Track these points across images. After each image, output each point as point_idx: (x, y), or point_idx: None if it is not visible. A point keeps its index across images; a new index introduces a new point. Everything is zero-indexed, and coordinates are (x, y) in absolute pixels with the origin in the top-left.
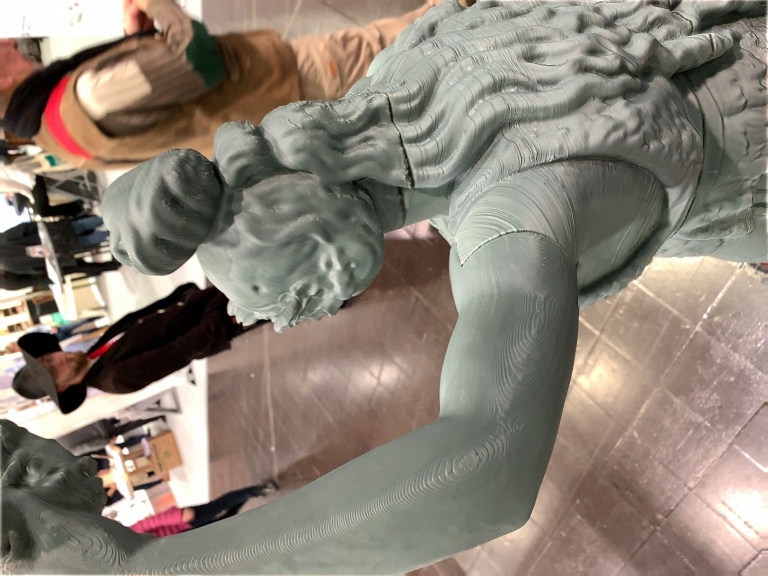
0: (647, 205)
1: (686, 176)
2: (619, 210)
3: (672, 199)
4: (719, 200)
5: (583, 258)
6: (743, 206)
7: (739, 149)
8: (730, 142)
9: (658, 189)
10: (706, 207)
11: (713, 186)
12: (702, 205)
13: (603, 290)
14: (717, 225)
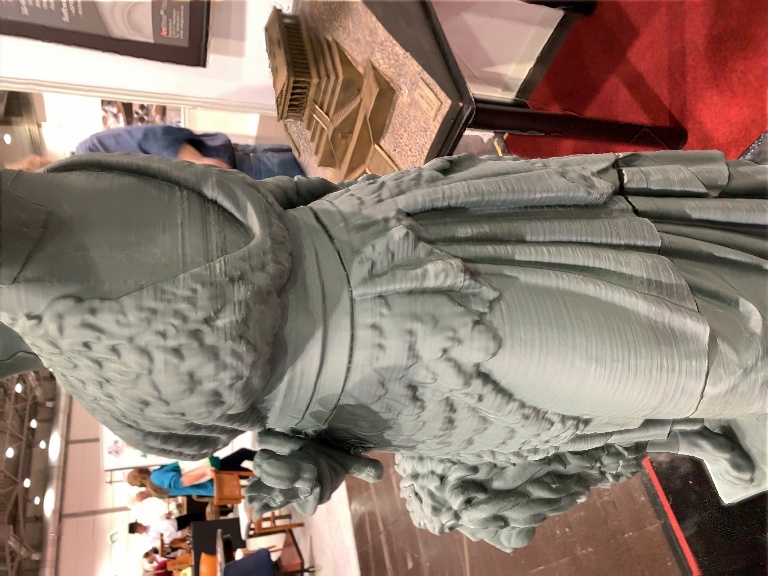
0: (188, 208)
1: (210, 176)
2: (126, 198)
3: (230, 208)
4: (368, 242)
5: (116, 253)
6: (397, 234)
7: (351, 202)
8: (341, 205)
9: (197, 198)
10: (358, 252)
11: (349, 234)
12: (352, 253)
13: (165, 283)
14: (398, 268)
